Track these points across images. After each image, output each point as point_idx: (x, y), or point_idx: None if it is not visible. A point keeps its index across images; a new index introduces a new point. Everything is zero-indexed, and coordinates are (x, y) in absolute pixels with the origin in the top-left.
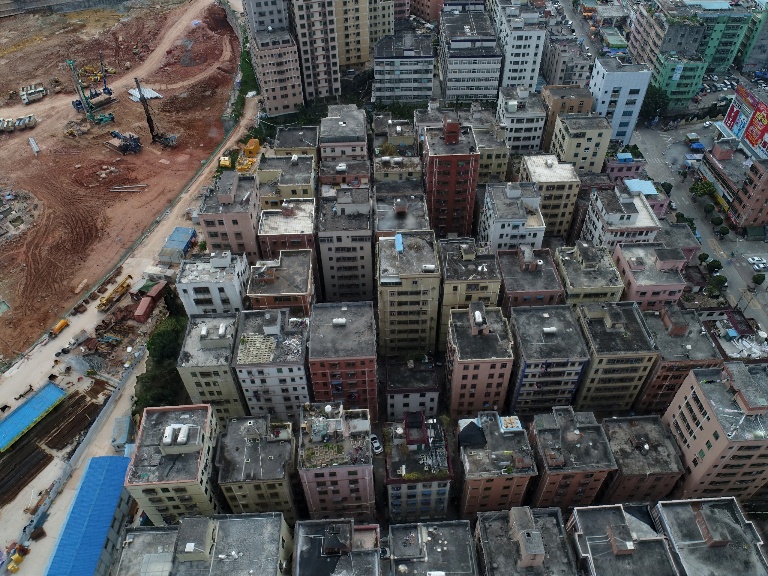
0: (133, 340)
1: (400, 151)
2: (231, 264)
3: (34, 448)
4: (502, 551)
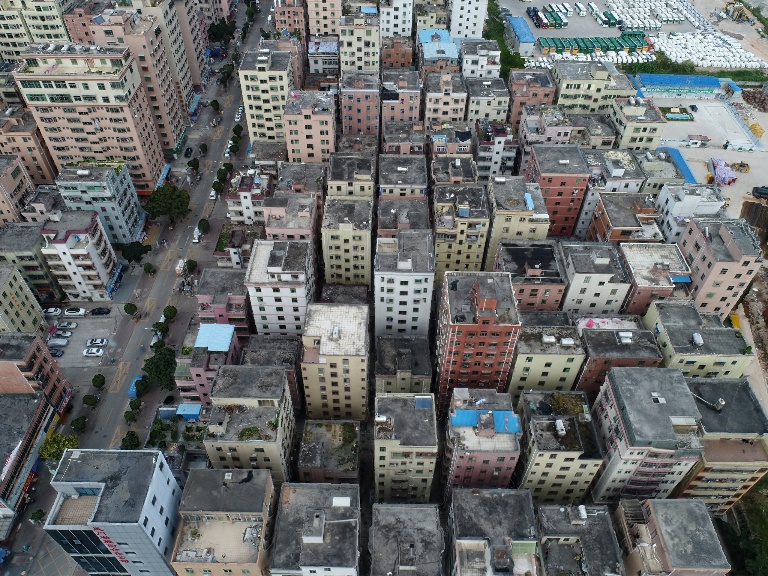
0: (759, 296)
1: (549, 411)
2: (677, 195)
3: (759, 224)
4: (457, 87)
